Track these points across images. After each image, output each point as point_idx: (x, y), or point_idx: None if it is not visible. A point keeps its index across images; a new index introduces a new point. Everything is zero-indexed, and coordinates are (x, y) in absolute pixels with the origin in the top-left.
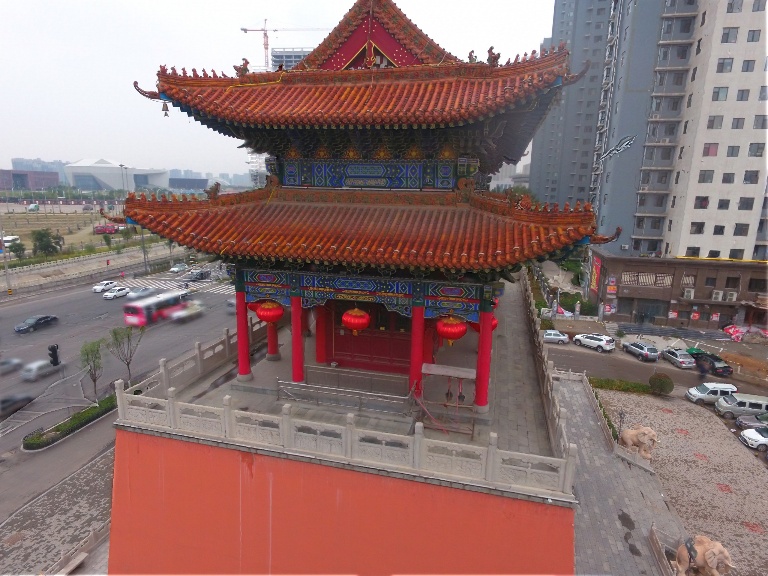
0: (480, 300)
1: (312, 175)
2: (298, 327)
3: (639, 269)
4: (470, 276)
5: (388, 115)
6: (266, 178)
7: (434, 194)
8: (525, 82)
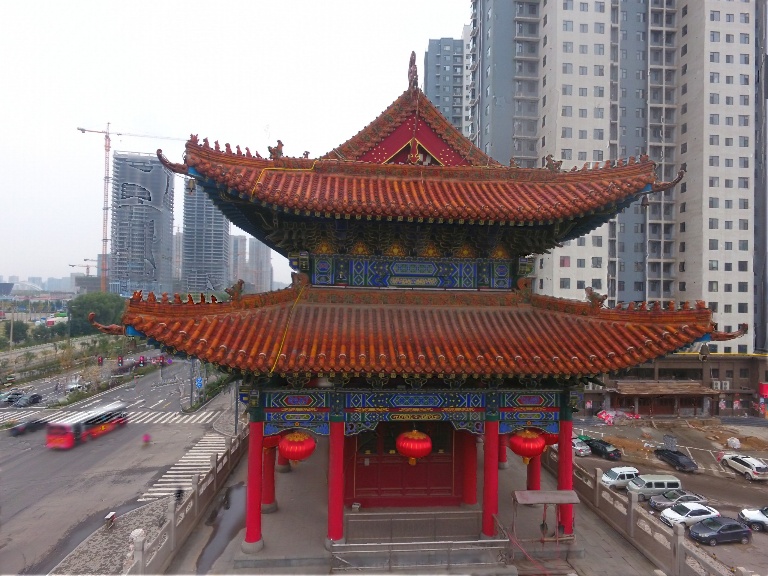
0: (560, 408)
1: (349, 273)
2: (340, 463)
3: None
4: (545, 381)
5: (472, 210)
6: (292, 276)
7: (494, 294)
8: (614, 187)
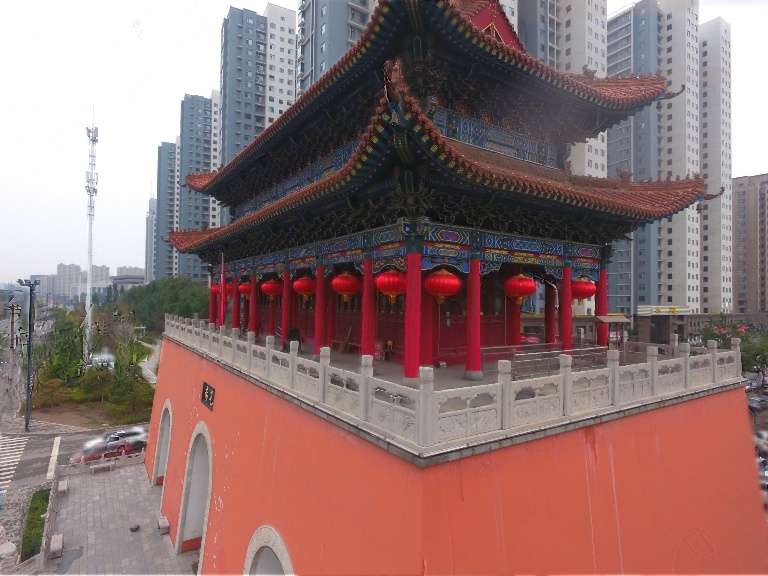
0: (601, 260)
1: (458, 130)
2: None
3: None
4: None
5: None
6: None
7: (552, 170)
8: None
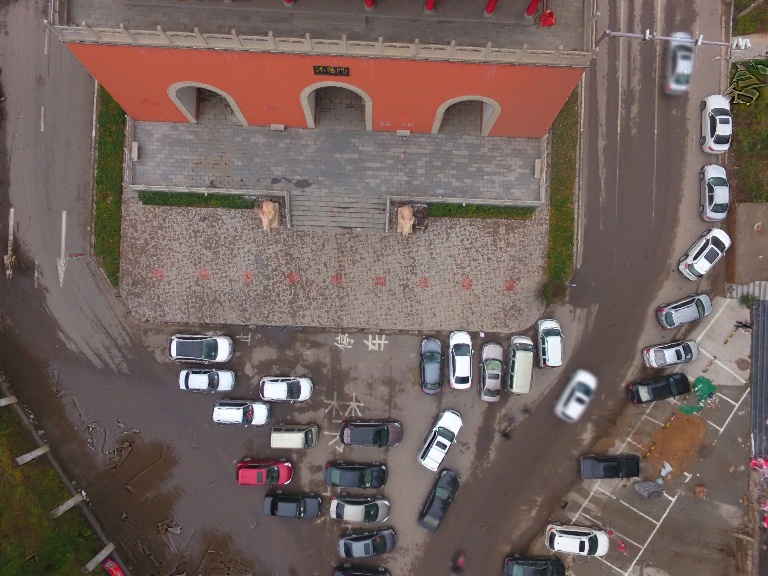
0: None
1: None
2: None
3: None
4: None
5: None
6: None
7: None
8: None
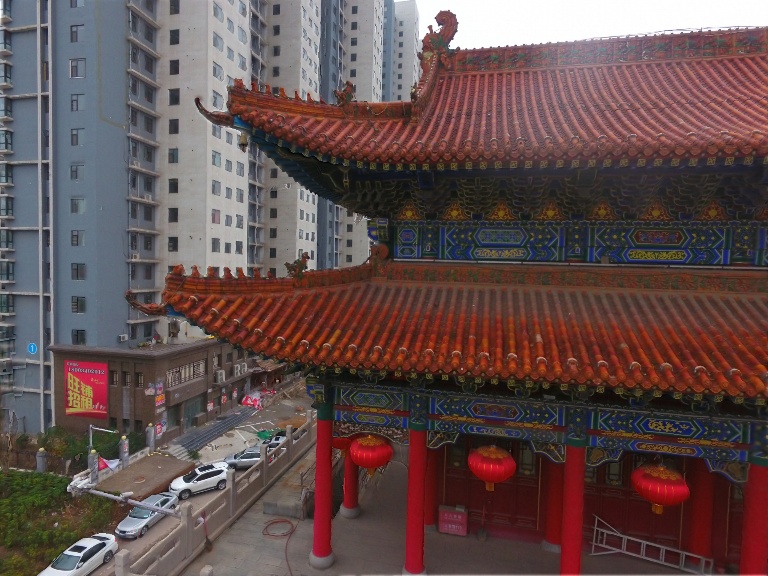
0: None
1: None
2: None
3: (181, 362)
4: None
5: None
6: None
7: None
8: None
